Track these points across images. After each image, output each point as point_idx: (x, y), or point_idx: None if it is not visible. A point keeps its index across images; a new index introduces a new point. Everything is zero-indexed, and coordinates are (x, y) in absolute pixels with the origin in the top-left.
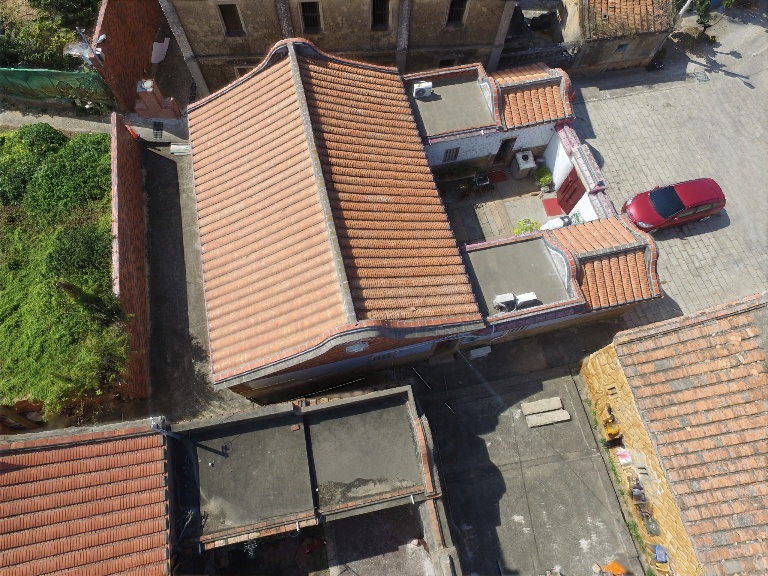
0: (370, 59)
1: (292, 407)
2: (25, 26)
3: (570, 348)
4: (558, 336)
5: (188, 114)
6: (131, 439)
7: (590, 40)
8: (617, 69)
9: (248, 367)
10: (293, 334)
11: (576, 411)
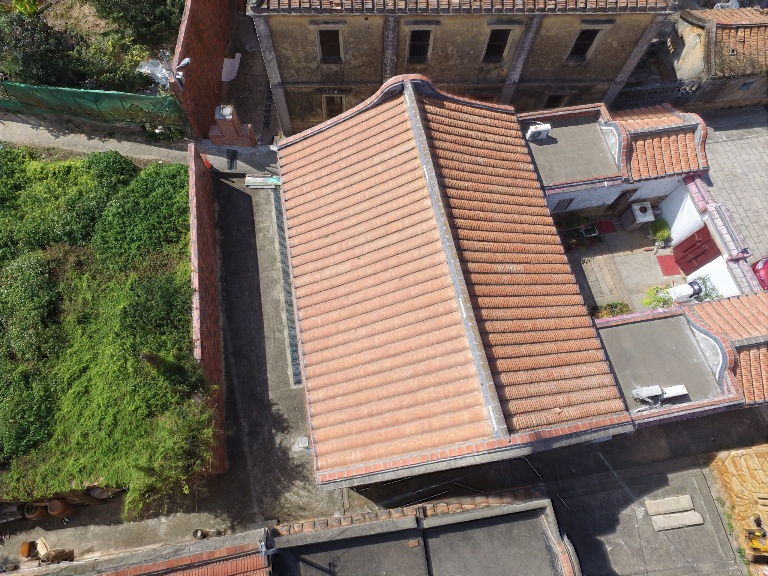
0: (474, 92)
1: (416, 523)
2: (95, 41)
3: (697, 435)
4: (683, 420)
5: (278, 151)
6: (232, 559)
7: (715, 77)
8: (733, 107)
9: (362, 469)
10: (419, 435)
11: (708, 513)
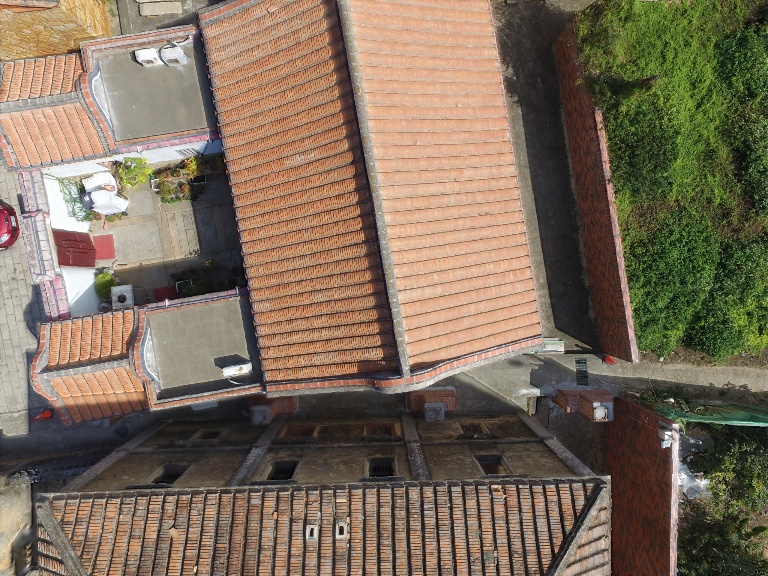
0: (307, 440)
1: None
2: None
3: None
4: None
5: None
6: None
7: None
8: None
9: None
10: None
11: (126, 3)
